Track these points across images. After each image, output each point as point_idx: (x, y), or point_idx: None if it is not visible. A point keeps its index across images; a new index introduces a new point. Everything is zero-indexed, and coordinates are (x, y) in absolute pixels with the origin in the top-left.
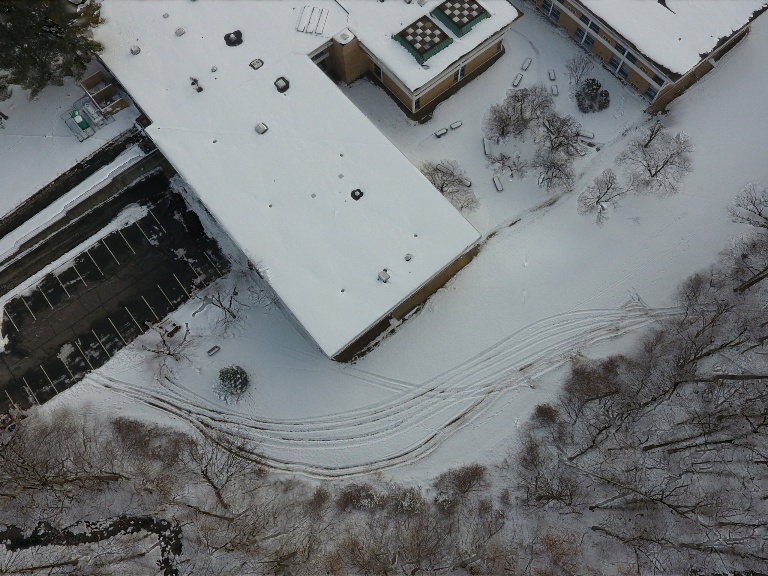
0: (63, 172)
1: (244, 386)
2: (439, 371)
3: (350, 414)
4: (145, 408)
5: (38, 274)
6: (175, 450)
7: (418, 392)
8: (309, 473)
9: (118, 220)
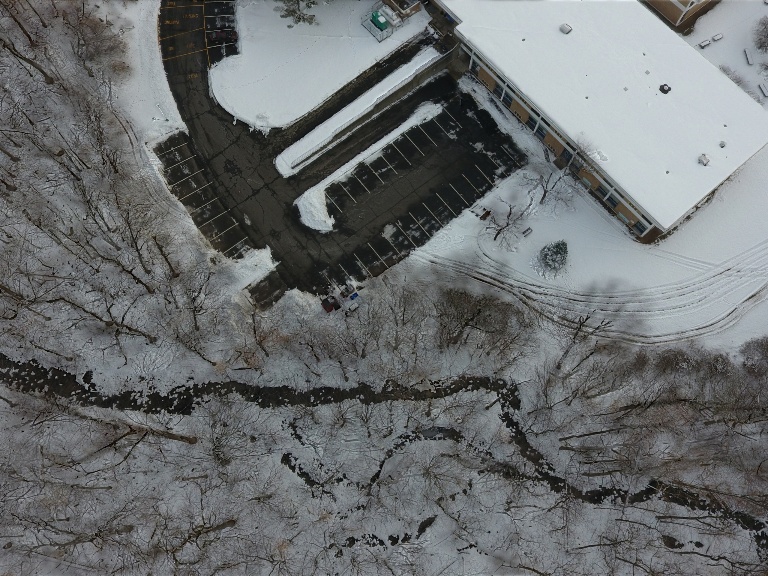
0: (364, 70)
1: (564, 262)
2: (734, 253)
3: (659, 289)
4: (471, 282)
5: (351, 162)
6: (505, 318)
7: (717, 271)
8: (627, 340)
9: (418, 115)
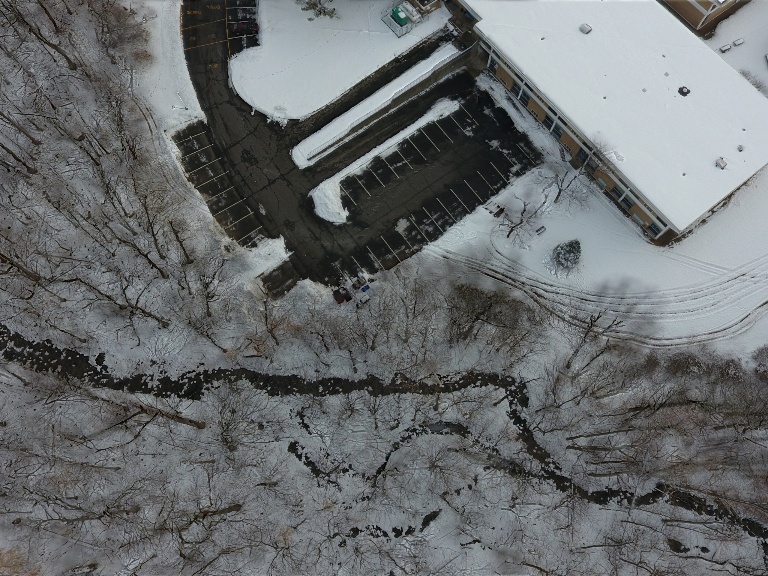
0: (383, 65)
1: None
2: (749, 258)
3: (672, 292)
4: (482, 278)
5: (367, 156)
6: (515, 315)
7: (732, 276)
8: (638, 342)
9: (434, 111)
